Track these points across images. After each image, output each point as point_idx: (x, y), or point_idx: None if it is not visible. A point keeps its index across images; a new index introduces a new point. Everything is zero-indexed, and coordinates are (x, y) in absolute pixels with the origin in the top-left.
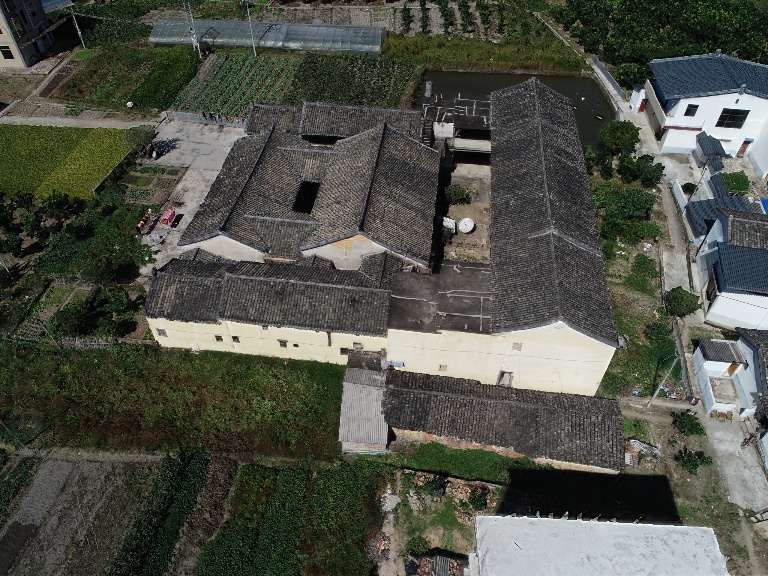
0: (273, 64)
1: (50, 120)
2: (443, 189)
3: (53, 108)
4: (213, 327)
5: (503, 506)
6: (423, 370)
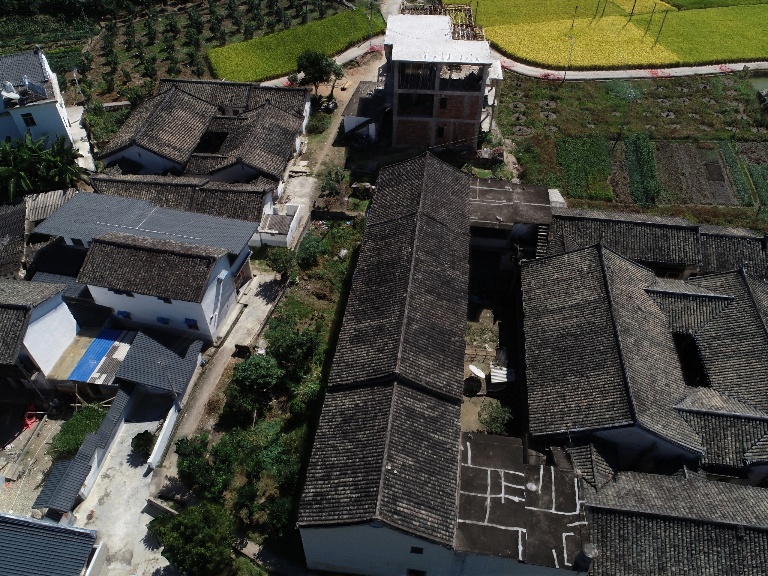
0: None
1: None
2: None
3: None
4: None
5: None
6: None
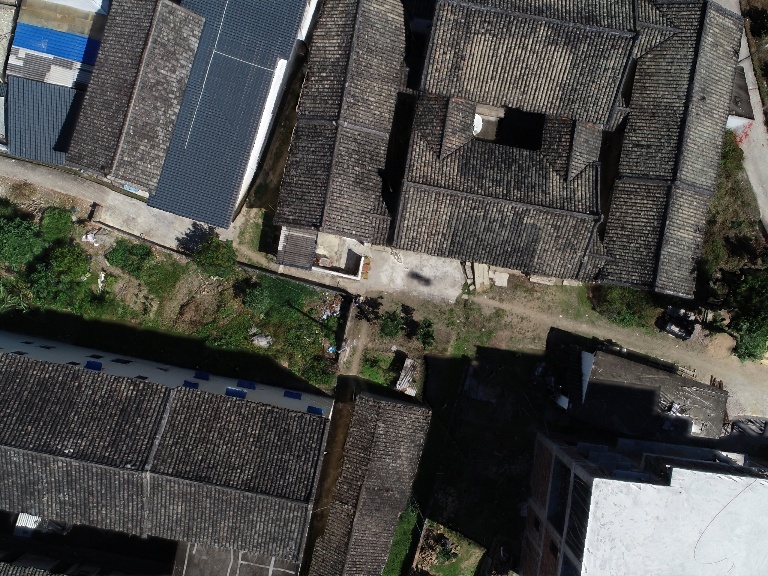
0: None
1: None
2: None
3: None
4: None
5: None
6: None
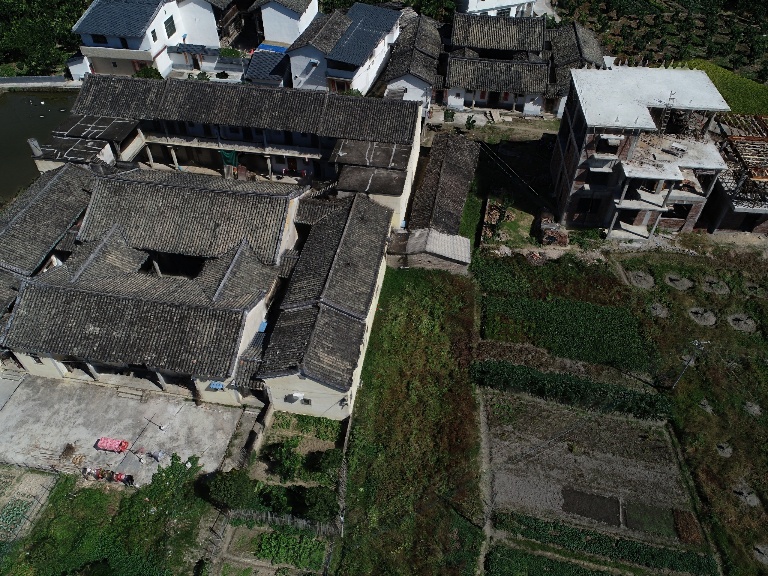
0: None
1: None
2: None
3: None
4: None
5: (507, 195)
6: None
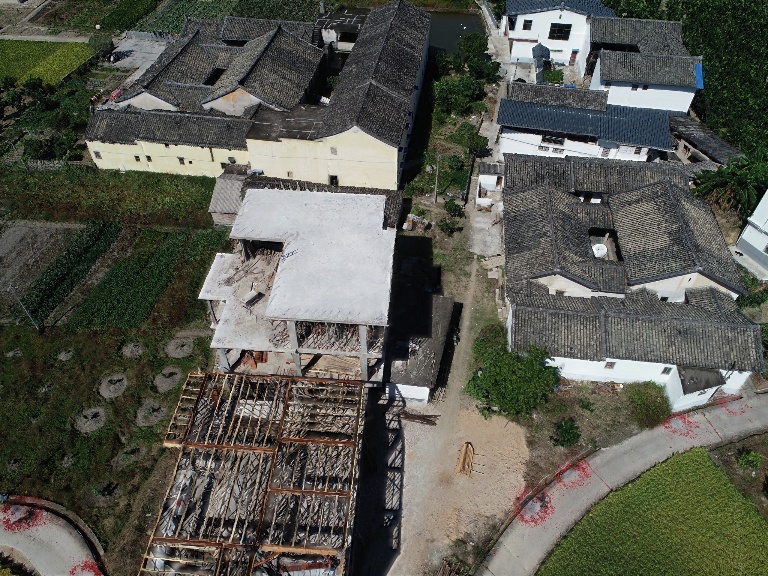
0: (219, 2)
1: (34, 37)
2: (326, 78)
3: (38, 30)
4: (132, 148)
5: None
6: (277, 177)
